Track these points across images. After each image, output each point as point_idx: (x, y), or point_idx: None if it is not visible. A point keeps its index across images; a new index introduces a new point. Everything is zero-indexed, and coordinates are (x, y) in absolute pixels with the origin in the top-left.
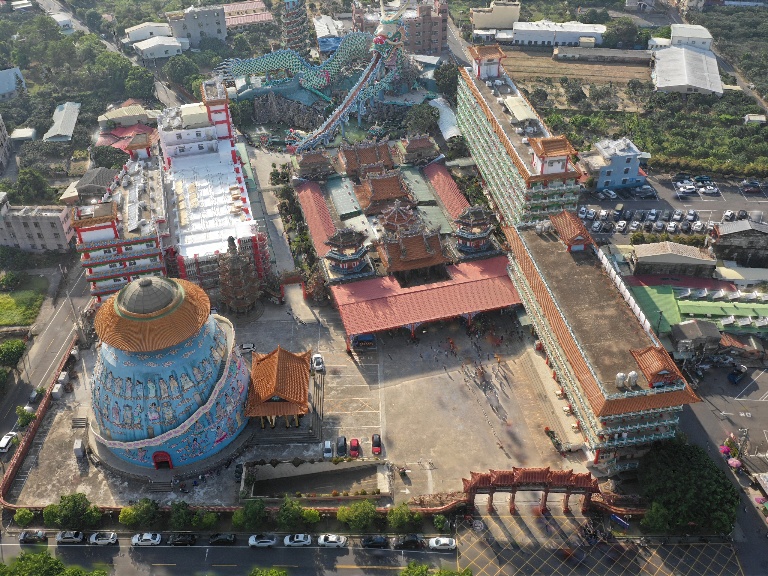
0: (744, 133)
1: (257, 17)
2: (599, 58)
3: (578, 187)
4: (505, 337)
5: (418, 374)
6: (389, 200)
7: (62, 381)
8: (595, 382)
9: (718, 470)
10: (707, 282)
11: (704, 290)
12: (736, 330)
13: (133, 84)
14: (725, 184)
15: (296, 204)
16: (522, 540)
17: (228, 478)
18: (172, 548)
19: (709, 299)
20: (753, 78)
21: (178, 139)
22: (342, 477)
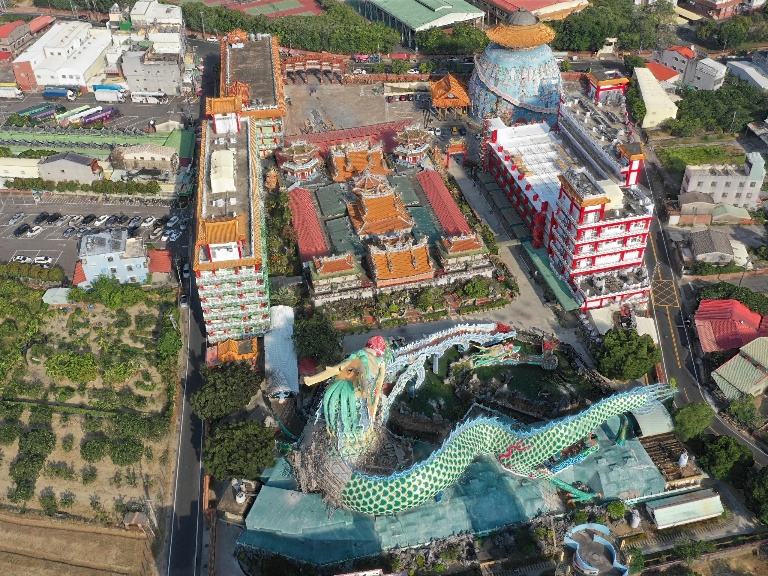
0: None
1: None
2: None
3: None
4: None
5: None
6: None
7: None
8: None
9: (220, 63)
10: None
11: None
12: None
13: None
14: None
15: None
16: None
17: None
18: None
19: None
20: None
21: None
22: None
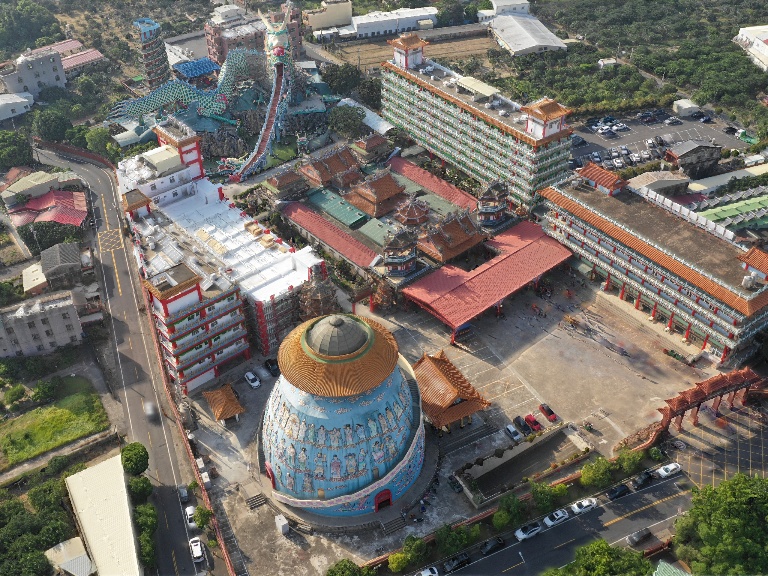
0: (607, 76)
1: (85, 57)
2: (443, 37)
3: (570, 142)
4: (569, 289)
5: (528, 343)
6: (390, 199)
7: (203, 469)
8: (728, 290)
9: None
10: (685, 198)
11: (693, 204)
12: (735, 228)
13: (10, 151)
14: (626, 119)
15: (292, 227)
16: (720, 443)
17: (447, 493)
18: (453, 574)
19: (699, 210)
20: (578, 30)
21: (153, 190)
22: (539, 452)
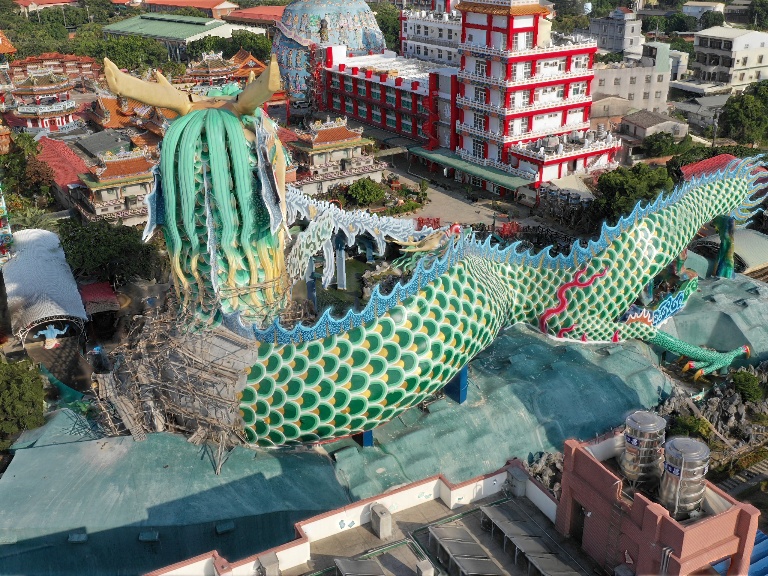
0: None
1: None
2: None
3: None
4: None
5: None
6: None
7: None
8: None
9: None
10: None
11: None
12: None
13: None
14: None
15: None
16: None
17: None
18: None
19: None
20: None
21: None
22: None
